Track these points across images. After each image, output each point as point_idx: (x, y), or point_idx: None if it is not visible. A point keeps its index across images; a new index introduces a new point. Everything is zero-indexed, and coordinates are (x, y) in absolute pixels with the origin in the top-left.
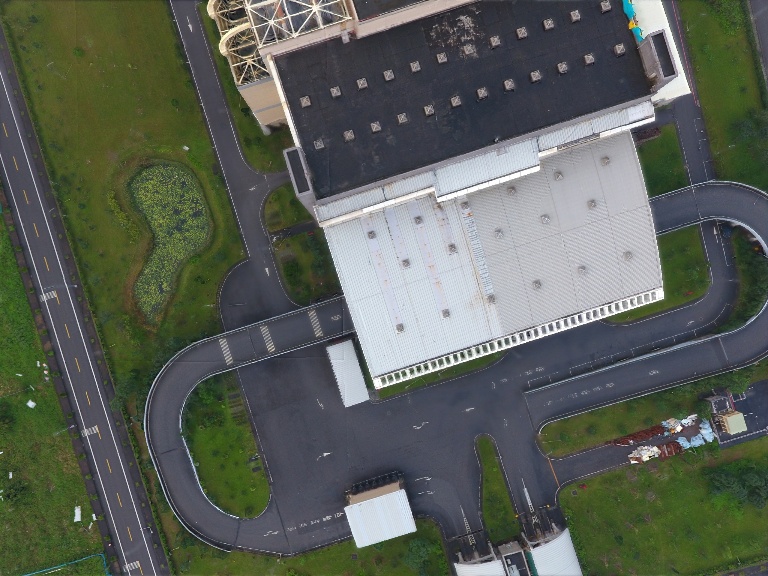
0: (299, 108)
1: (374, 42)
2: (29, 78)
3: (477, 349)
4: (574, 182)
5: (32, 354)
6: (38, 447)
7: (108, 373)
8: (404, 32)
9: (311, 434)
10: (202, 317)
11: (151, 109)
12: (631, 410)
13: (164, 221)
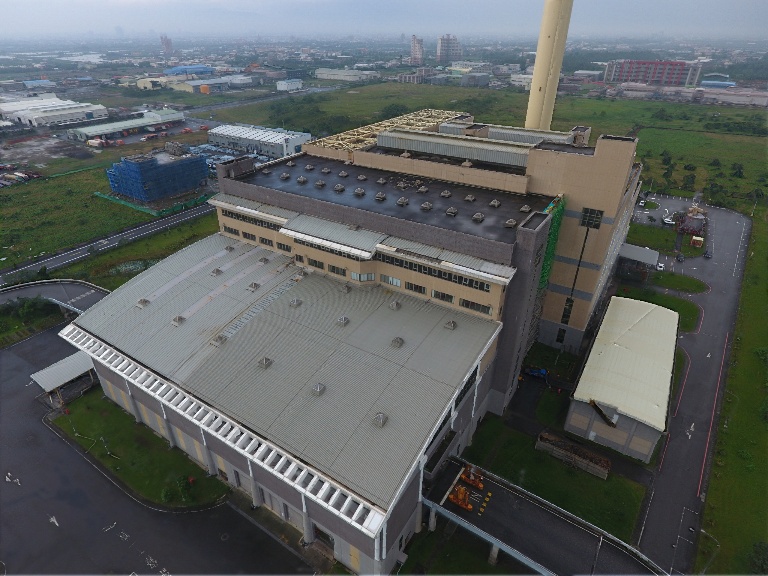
0: None
1: None
2: None
3: None
4: (403, 319)
5: (51, 248)
6: None
7: None
8: (378, 172)
9: None
10: None
11: None
12: None
13: None
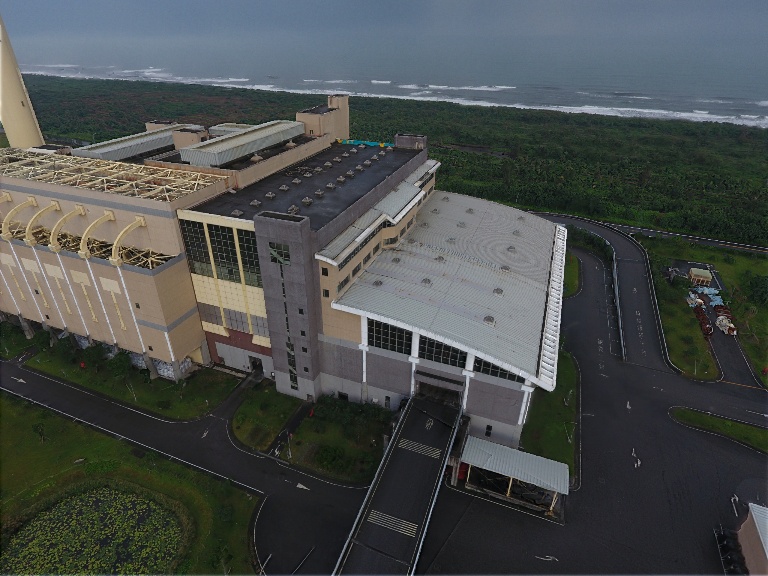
0: None
1: (255, 187)
2: None
3: None
4: (447, 211)
5: None
6: None
7: None
8: None
9: None
10: None
11: None
12: (670, 309)
13: (89, 571)
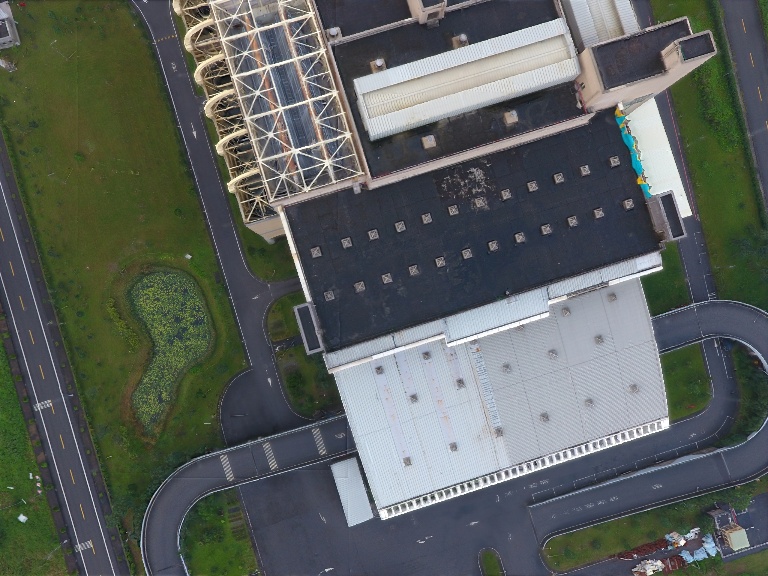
0: (309, 258)
1: (386, 193)
2: (28, 182)
3: (484, 478)
4: (581, 318)
5: (25, 466)
6: (29, 563)
7: (104, 485)
8: (416, 183)
9: (313, 549)
10: (202, 428)
11: (153, 215)
12: (635, 525)
13: (164, 329)
